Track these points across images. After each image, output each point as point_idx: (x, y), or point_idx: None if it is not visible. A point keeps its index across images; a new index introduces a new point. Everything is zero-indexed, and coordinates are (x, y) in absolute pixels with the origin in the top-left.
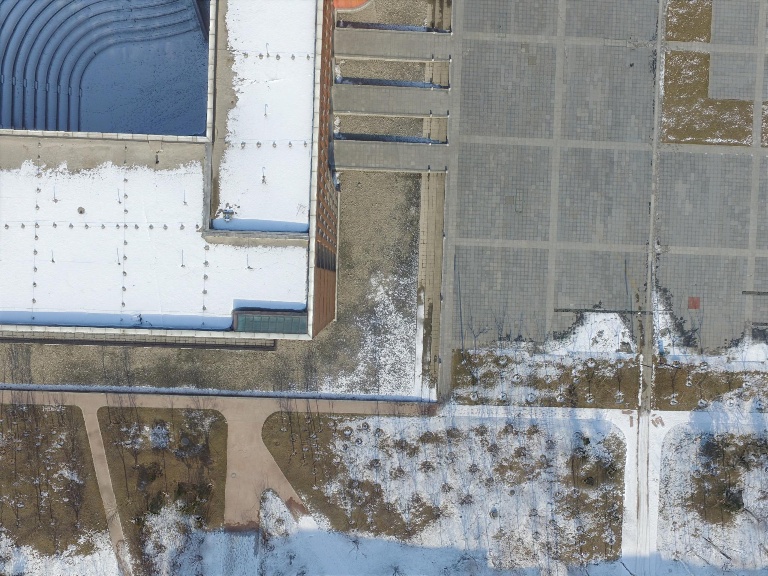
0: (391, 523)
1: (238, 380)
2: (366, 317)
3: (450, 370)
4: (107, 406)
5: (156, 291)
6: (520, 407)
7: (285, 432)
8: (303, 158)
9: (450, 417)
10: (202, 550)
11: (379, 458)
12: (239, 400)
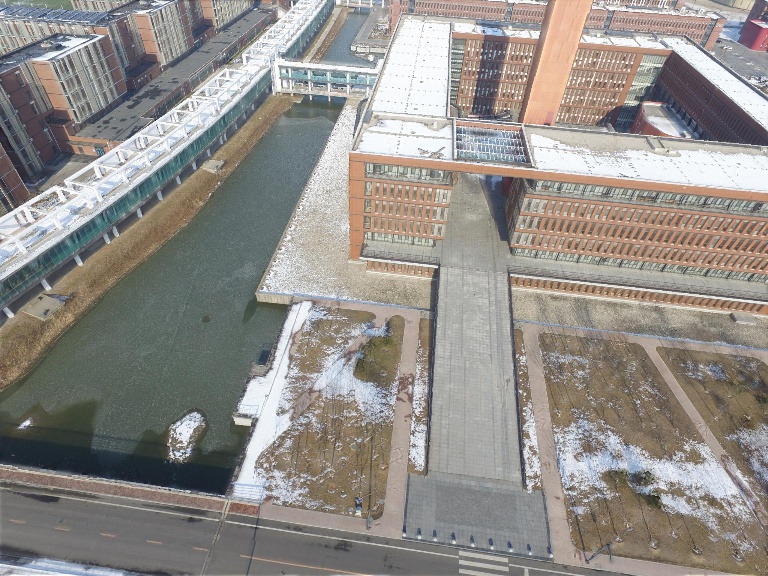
0: None
1: (759, 342)
2: None
3: None
4: (662, 346)
5: None
6: None
7: None
8: None
9: None
10: None
11: None
12: None
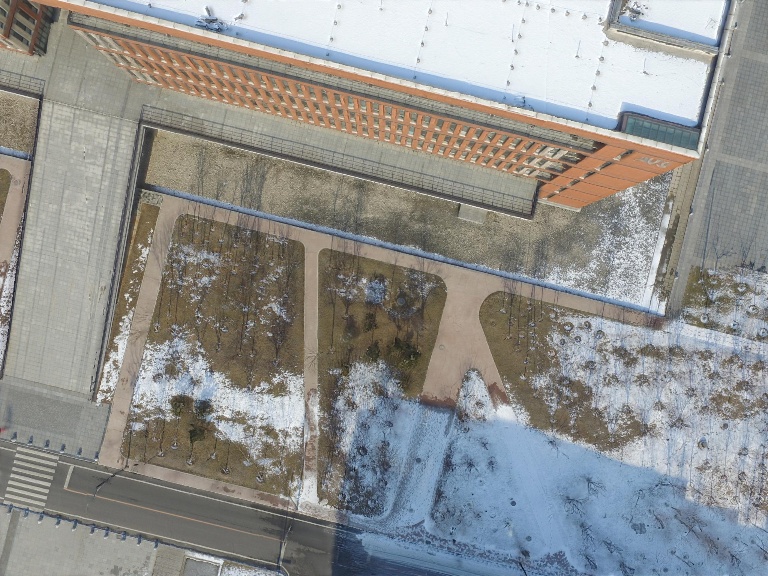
0: (594, 430)
1: (466, 251)
2: (609, 214)
3: (685, 286)
4: (330, 249)
5: (544, 77)
6: (749, 340)
7: (504, 314)
8: None
9: (675, 335)
10: (394, 417)
11: (596, 361)
12: (464, 271)
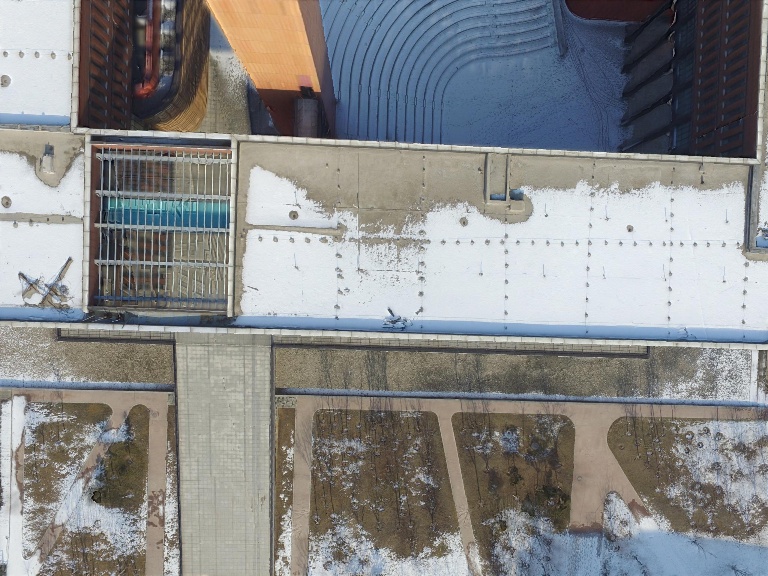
0: (731, 524)
1: (584, 386)
2: None
3: None
4: (461, 412)
5: (699, 306)
6: None
7: (630, 436)
8: None
9: None
10: None
11: (720, 461)
12: (587, 406)
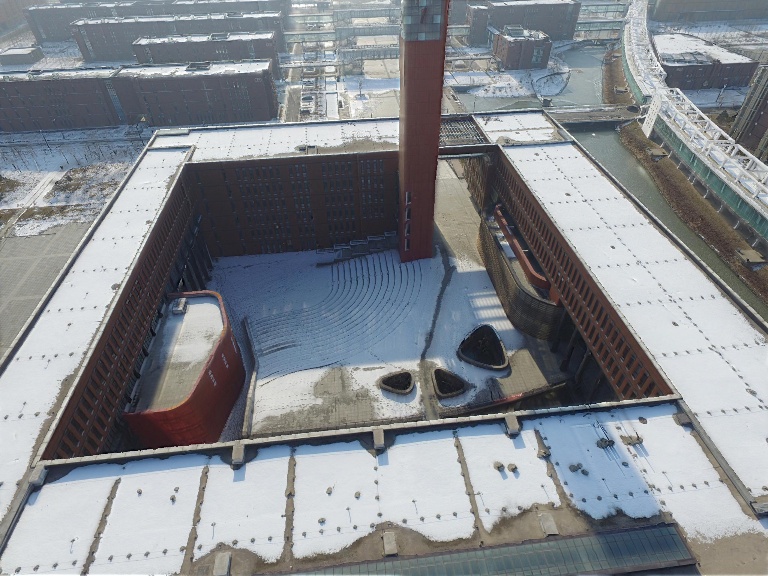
0: None
1: None
2: None
3: None
4: None
5: None
6: None
7: None
8: None
9: None
10: None
11: None
12: None
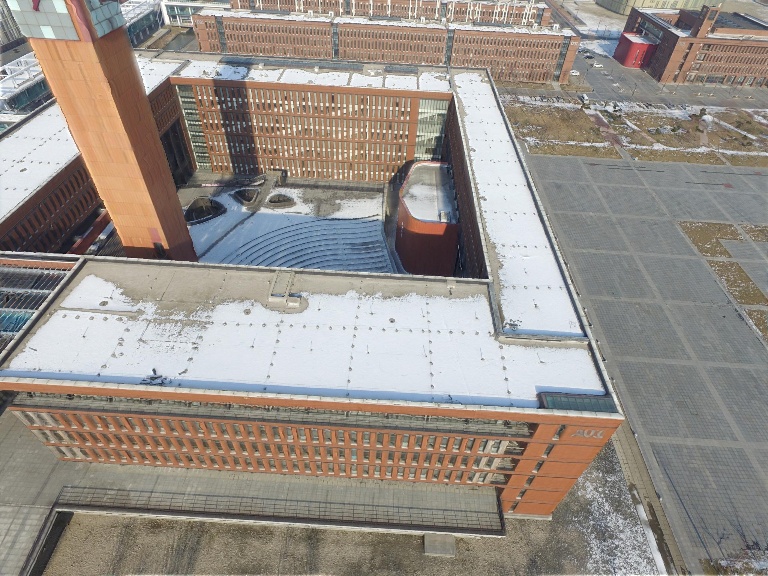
0: None
1: None
2: (583, 517)
3: None
4: None
5: (461, 377)
6: None
7: None
8: (562, 295)
9: None
10: None
11: None
12: None
